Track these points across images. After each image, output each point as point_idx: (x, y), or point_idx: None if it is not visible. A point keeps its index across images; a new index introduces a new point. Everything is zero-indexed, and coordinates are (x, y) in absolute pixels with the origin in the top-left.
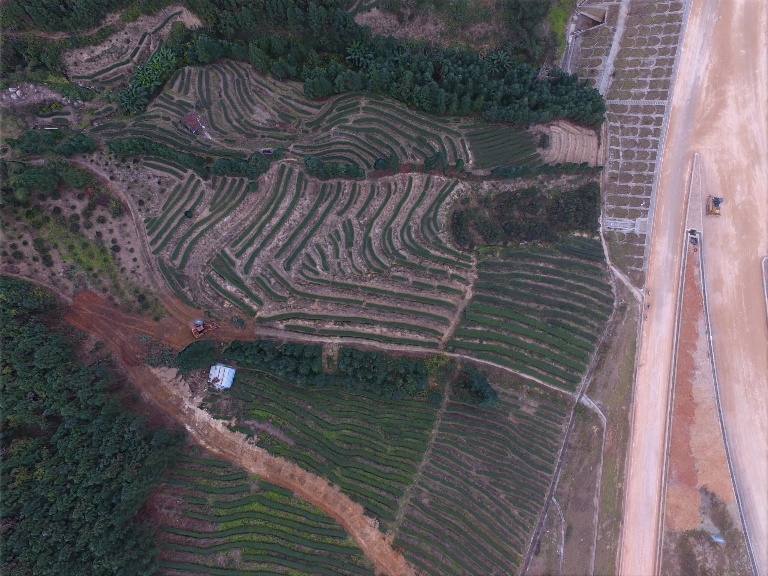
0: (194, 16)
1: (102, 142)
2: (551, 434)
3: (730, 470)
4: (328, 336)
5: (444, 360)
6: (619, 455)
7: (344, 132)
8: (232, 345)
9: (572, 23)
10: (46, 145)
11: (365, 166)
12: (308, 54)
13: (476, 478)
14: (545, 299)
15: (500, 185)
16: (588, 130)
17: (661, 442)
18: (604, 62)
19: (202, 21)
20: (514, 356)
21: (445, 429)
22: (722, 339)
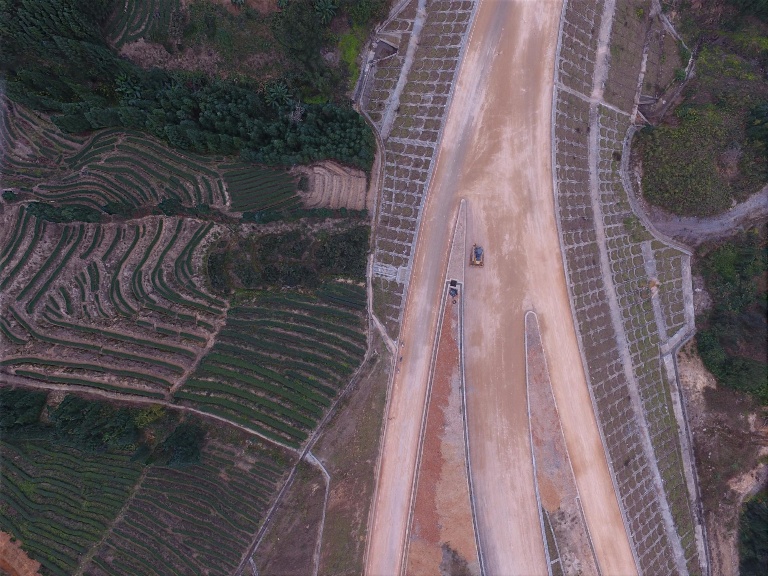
0: None
1: None
2: (264, 492)
3: (475, 528)
4: (56, 383)
5: (156, 415)
6: (360, 509)
7: (93, 172)
8: None
9: (371, 51)
10: None
11: None
12: None
13: (170, 536)
14: (289, 350)
15: (261, 227)
16: (357, 171)
17: (408, 497)
18: (391, 96)
19: None
20: (240, 410)
21: (147, 485)
22: (477, 395)
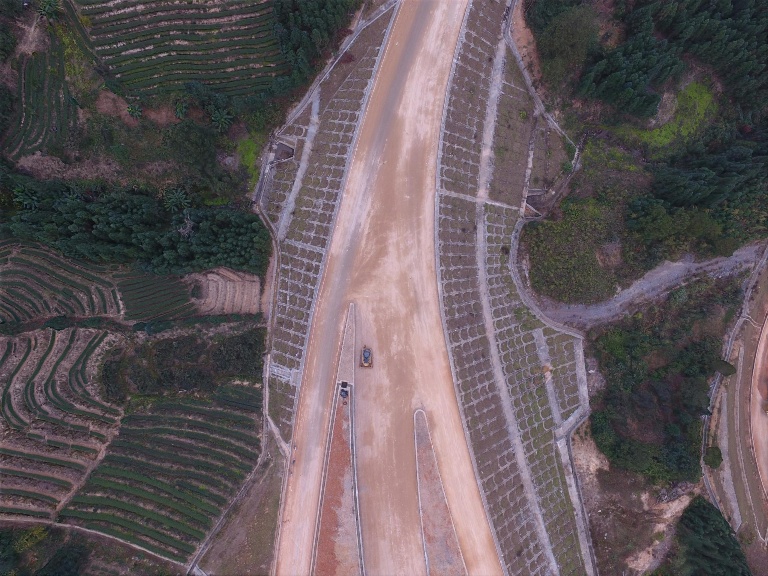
0: None
1: None
2: None
3: None
4: None
5: (37, 538)
6: None
7: None
8: None
9: (271, 152)
10: None
11: None
12: None
13: None
14: (181, 458)
15: None
16: (251, 276)
17: None
18: (287, 199)
19: None
20: (126, 526)
21: None
22: (370, 494)
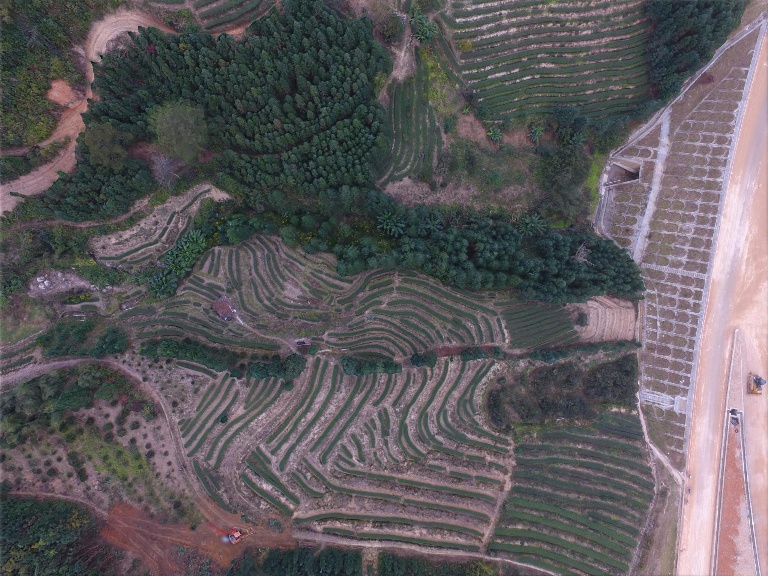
0: (223, 191)
1: (133, 335)
2: None
3: None
4: (367, 540)
5: (487, 574)
6: None
7: (379, 316)
8: (272, 564)
9: (605, 174)
10: (76, 342)
11: (401, 353)
12: (339, 224)
13: None
14: (585, 489)
15: (536, 361)
16: (625, 302)
17: None
18: (639, 222)
19: (231, 196)
20: (556, 559)
21: None
22: (764, 522)
